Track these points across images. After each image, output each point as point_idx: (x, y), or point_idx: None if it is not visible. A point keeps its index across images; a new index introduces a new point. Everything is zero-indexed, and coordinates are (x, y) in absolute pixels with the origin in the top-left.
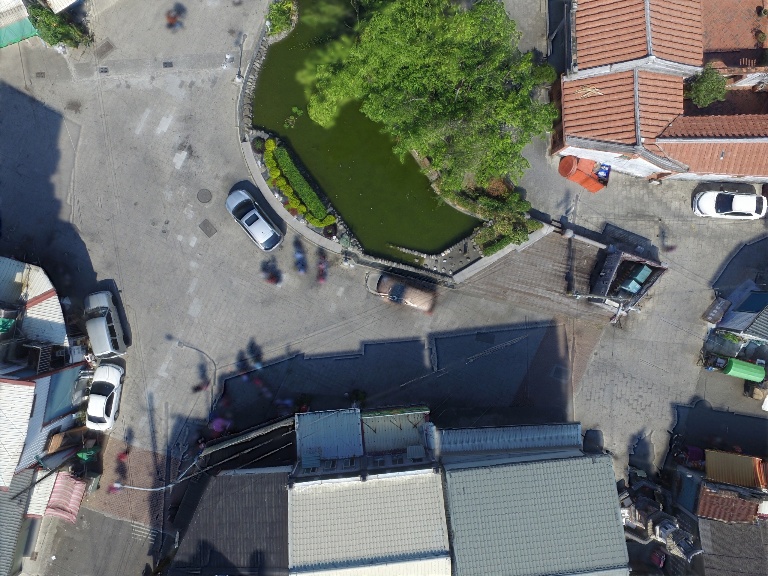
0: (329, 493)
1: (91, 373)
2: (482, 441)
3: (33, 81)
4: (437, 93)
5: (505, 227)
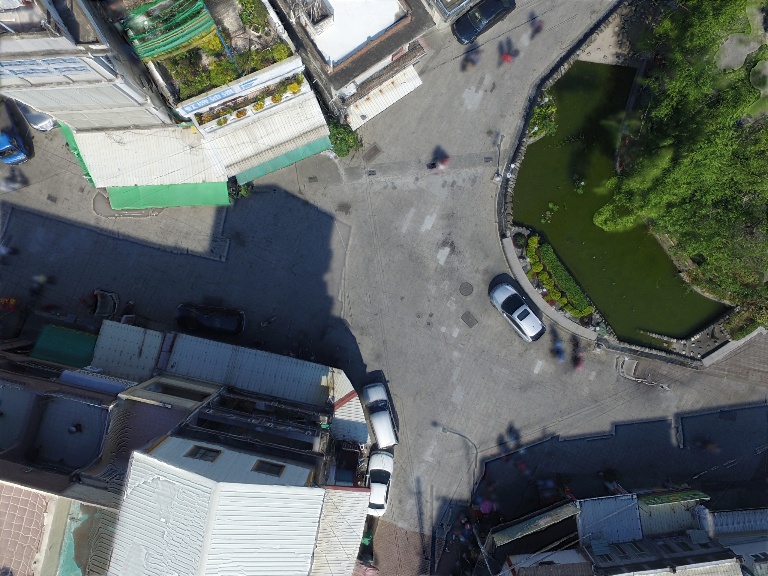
0: None
1: (363, 460)
2: (752, 522)
3: (306, 185)
4: (721, 199)
5: (764, 316)
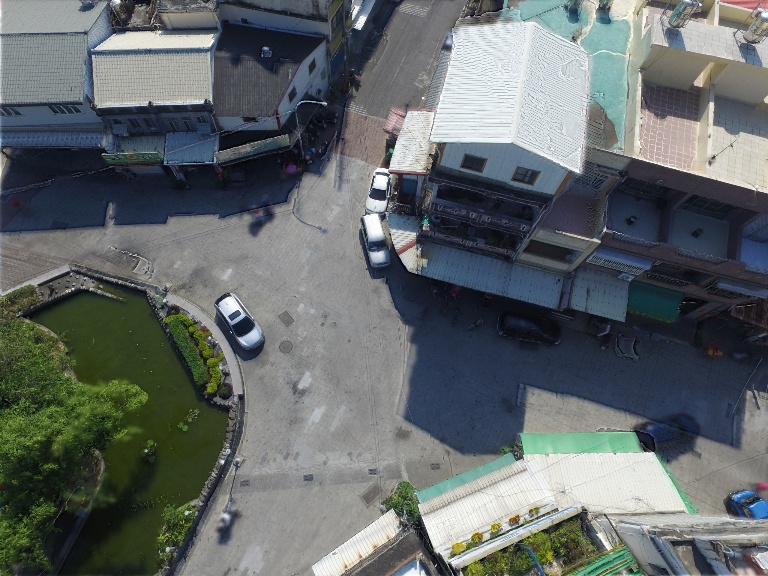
0: (181, 99)
1: None
2: (70, 138)
3: (442, 460)
4: None
5: None
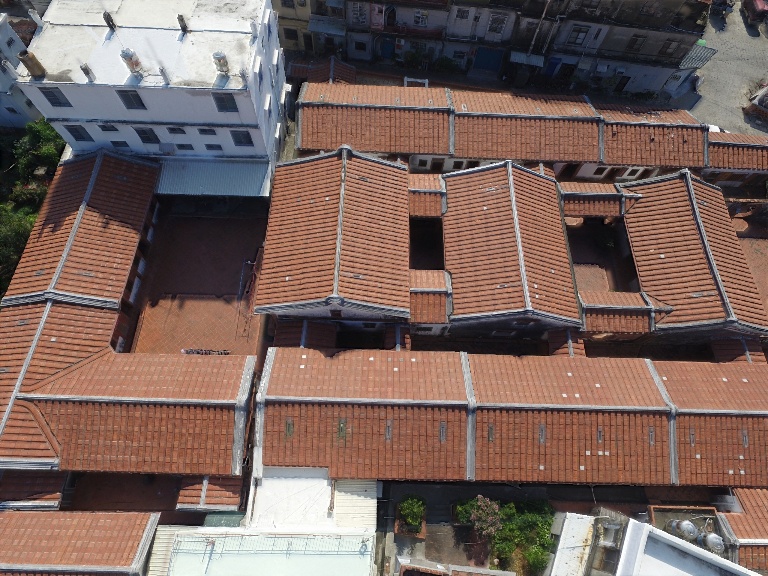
0: None
1: None
2: None
3: None
4: None
5: None
